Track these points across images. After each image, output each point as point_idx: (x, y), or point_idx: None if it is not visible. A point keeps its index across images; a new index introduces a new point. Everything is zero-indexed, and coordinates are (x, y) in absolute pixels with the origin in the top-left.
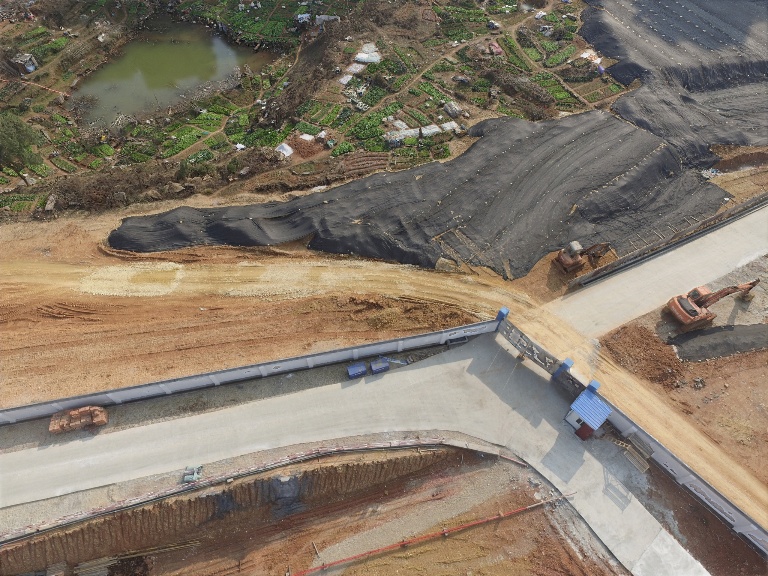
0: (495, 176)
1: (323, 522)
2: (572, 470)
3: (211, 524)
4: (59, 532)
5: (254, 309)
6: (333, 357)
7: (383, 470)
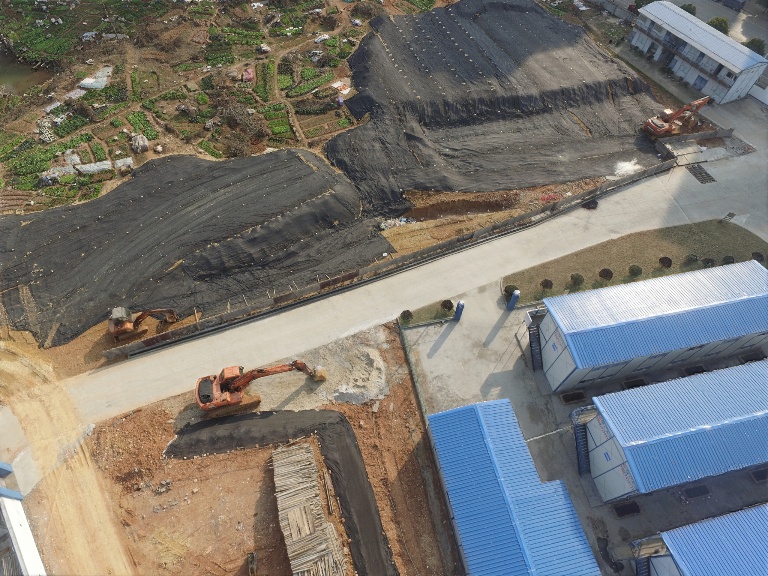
0: (115, 223)
1: None
2: None
3: None
4: None
5: None
6: None
7: None
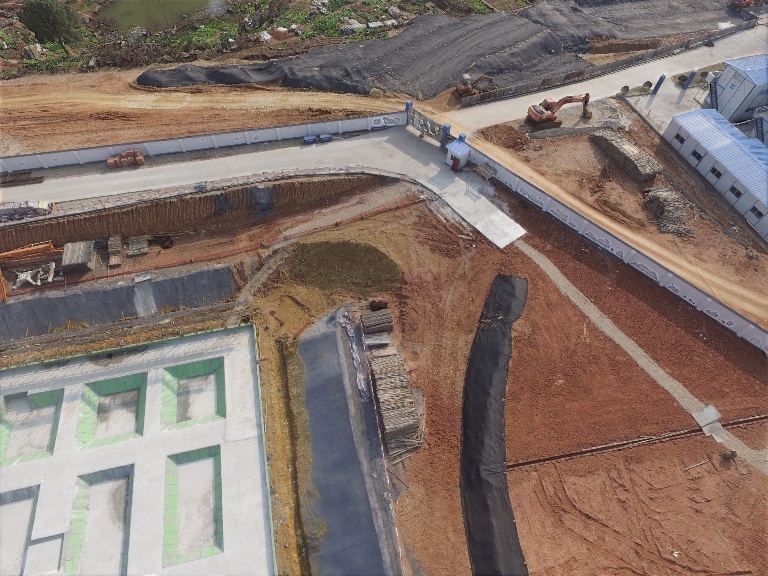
0: (419, 46)
1: (286, 219)
2: (446, 185)
3: (214, 219)
4: (118, 210)
5: (241, 114)
6: (294, 132)
7: (325, 187)
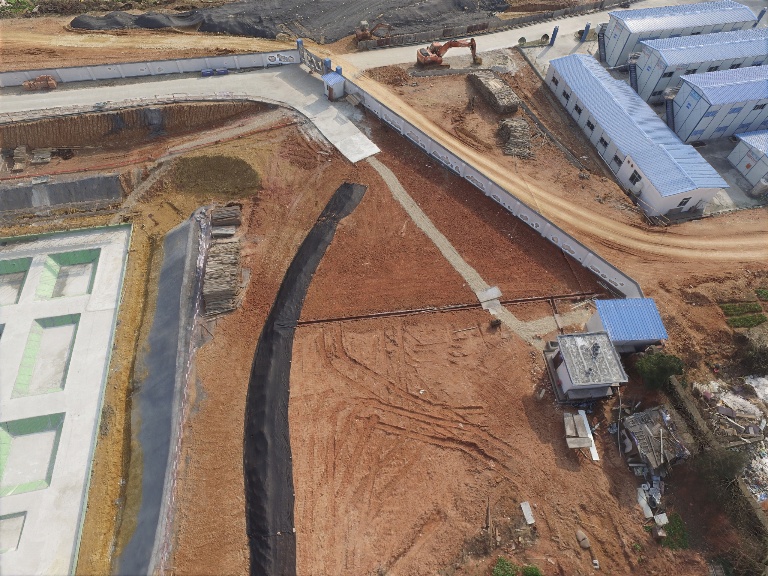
0: None
1: (175, 138)
2: (319, 111)
3: (111, 137)
4: (24, 123)
5: None
6: (195, 66)
7: (211, 111)
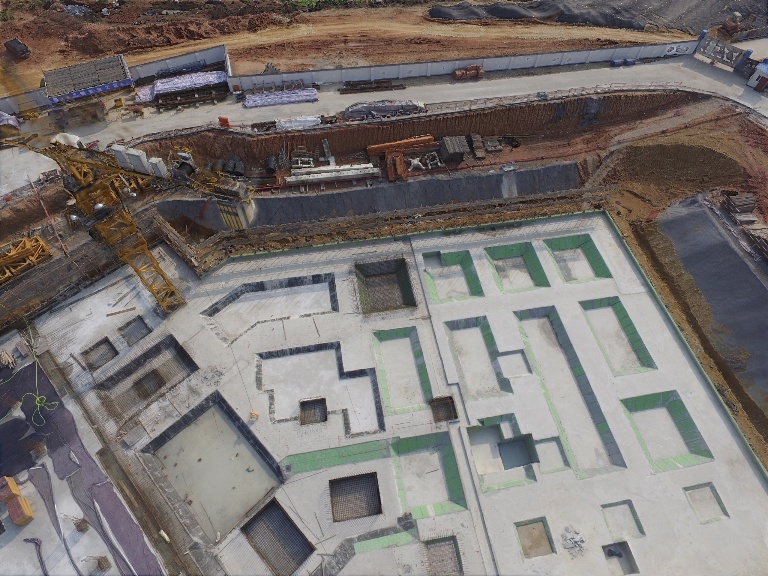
0: None
1: (611, 128)
2: (756, 101)
3: (549, 125)
4: (481, 111)
5: (539, 42)
6: (602, 56)
7: (646, 100)
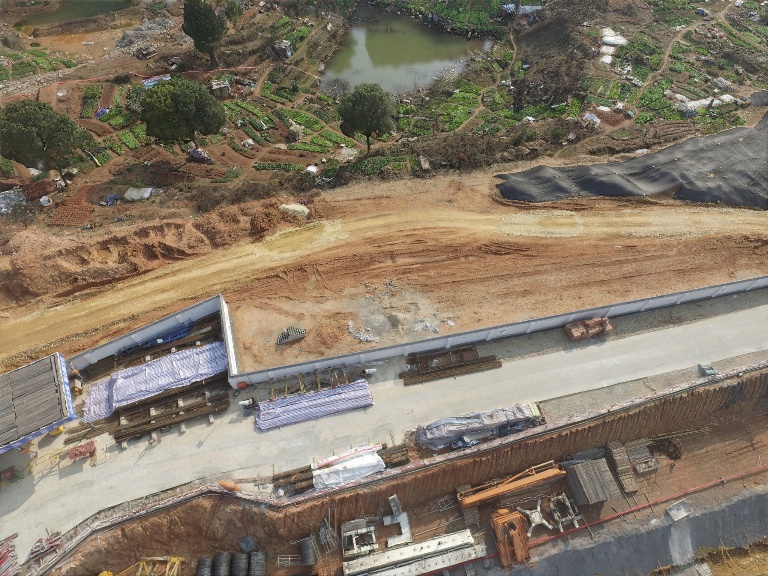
0: None
1: None
2: None
3: (718, 413)
4: (624, 413)
5: (666, 246)
6: None
7: None
